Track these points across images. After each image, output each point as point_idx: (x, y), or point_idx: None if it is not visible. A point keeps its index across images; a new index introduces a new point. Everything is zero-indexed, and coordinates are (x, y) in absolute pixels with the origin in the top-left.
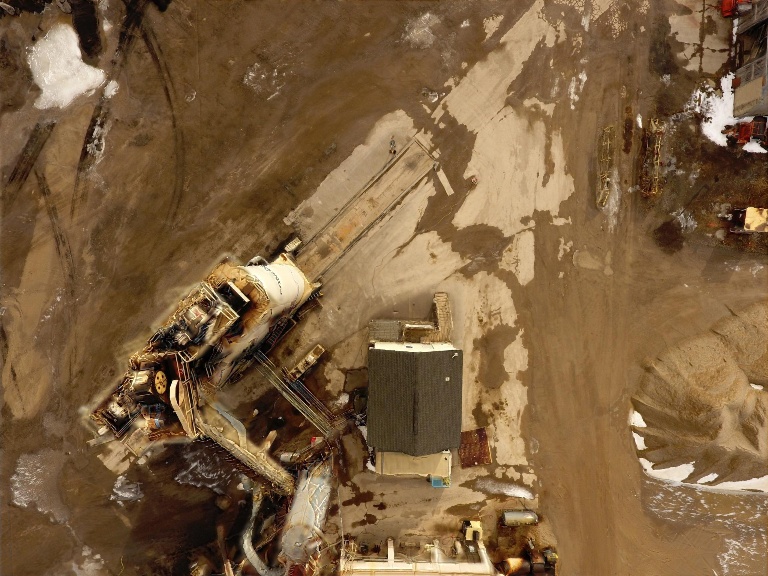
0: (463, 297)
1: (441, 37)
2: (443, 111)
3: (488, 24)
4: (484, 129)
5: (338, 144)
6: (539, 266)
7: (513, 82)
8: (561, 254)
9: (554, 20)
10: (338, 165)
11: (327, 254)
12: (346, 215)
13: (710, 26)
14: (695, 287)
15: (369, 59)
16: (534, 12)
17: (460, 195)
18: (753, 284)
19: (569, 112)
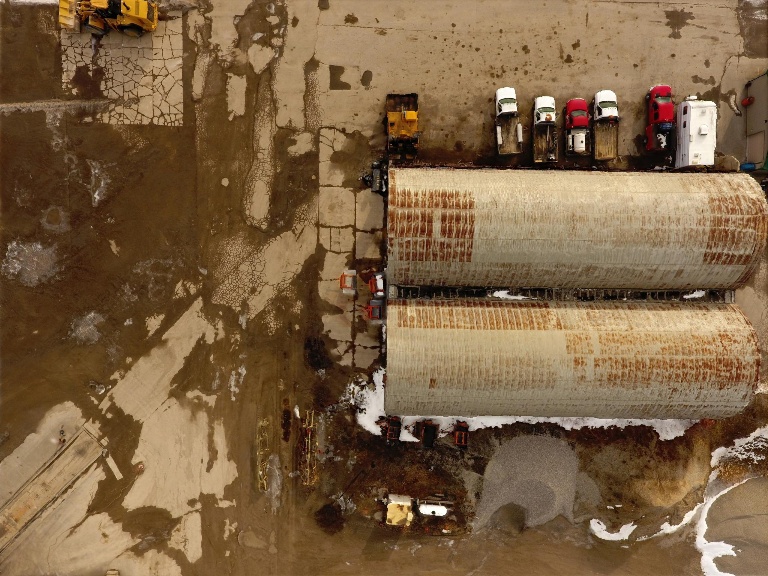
0: (134, 574)
1: (106, 334)
2: (110, 402)
3: (150, 322)
4: (149, 419)
5: (11, 432)
6: (206, 545)
7: (176, 376)
8: (227, 534)
9: (213, 319)
10: (11, 452)
11: (3, 534)
12: (20, 498)
13: (361, 325)
14: (357, 565)
15: (38, 354)
16: (193, 311)
17: (129, 479)
18: (412, 562)
19: (230, 403)
